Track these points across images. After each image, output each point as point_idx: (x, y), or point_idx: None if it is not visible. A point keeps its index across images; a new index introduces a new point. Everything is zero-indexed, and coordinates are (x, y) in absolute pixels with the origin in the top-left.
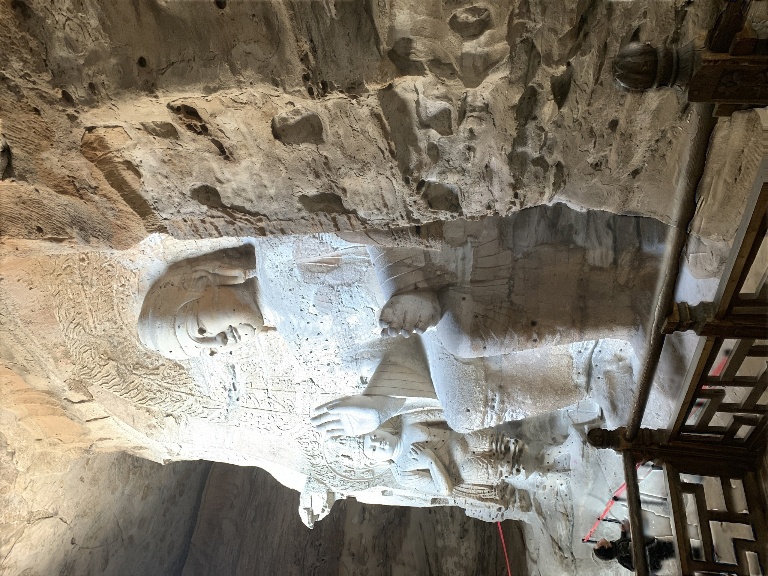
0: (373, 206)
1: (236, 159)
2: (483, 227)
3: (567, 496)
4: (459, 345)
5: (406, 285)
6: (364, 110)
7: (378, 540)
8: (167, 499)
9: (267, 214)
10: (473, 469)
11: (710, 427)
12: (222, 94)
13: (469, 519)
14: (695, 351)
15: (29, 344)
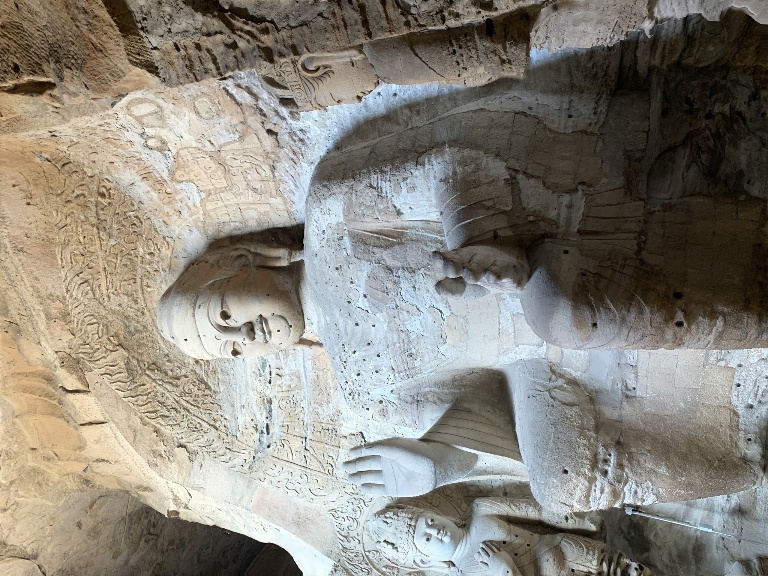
0: None
1: None
2: (602, 175)
3: None
4: (553, 315)
5: (482, 232)
6: None
7: None
8: None
9: (275, 19)
10: None
11: None
12: None
13: None
14: None
15: (20, 285)
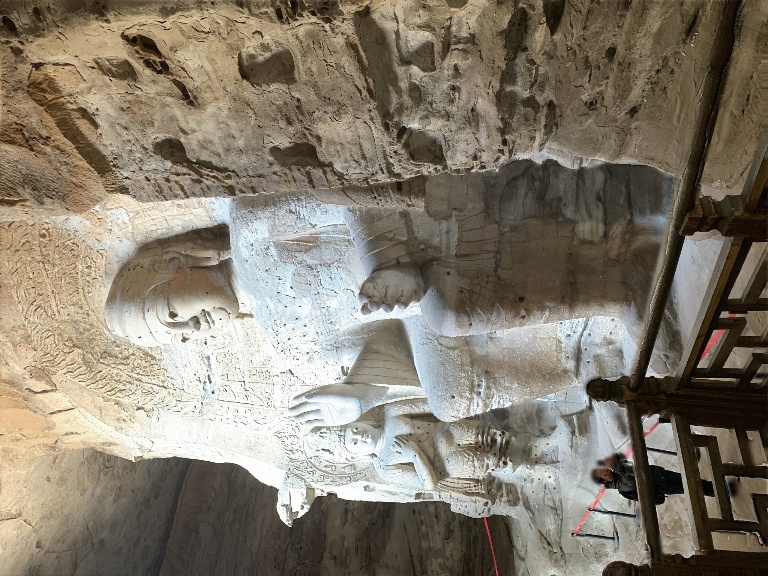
0: (350, 158)
1: (201, 104)
2: (468, 200)
3: (555, 489)
4: (444, 322)
5: (388, 259)
6: (339, 39)
7: (361, 542)
8: (141, 502)
9: (236, 170)
10: (458, 462)
11: (725, 369)
12: (181, 17)
13: (454, 519)
14: (717, 261)
15: None
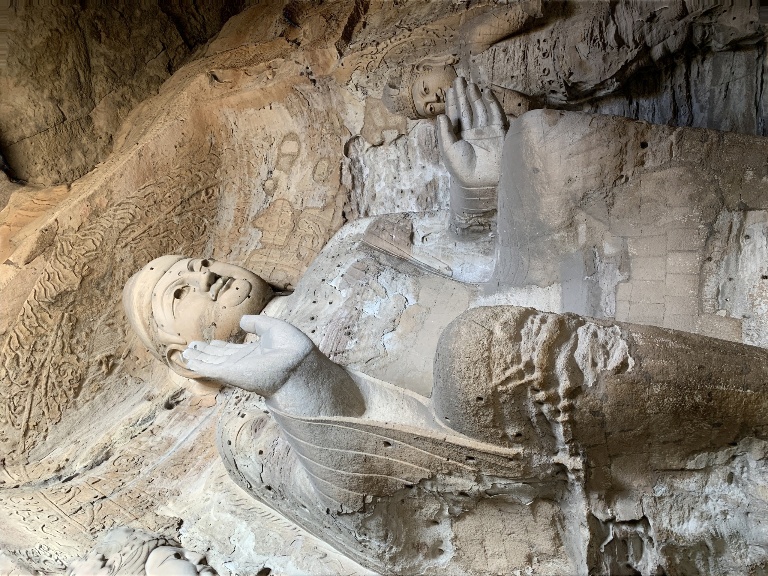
0: None
1: None
2: None
3: None
4: None
5: None
6: None
7: None
8: None
9: None
10: None
11: None
12: None
13: None
14: None
15: None
